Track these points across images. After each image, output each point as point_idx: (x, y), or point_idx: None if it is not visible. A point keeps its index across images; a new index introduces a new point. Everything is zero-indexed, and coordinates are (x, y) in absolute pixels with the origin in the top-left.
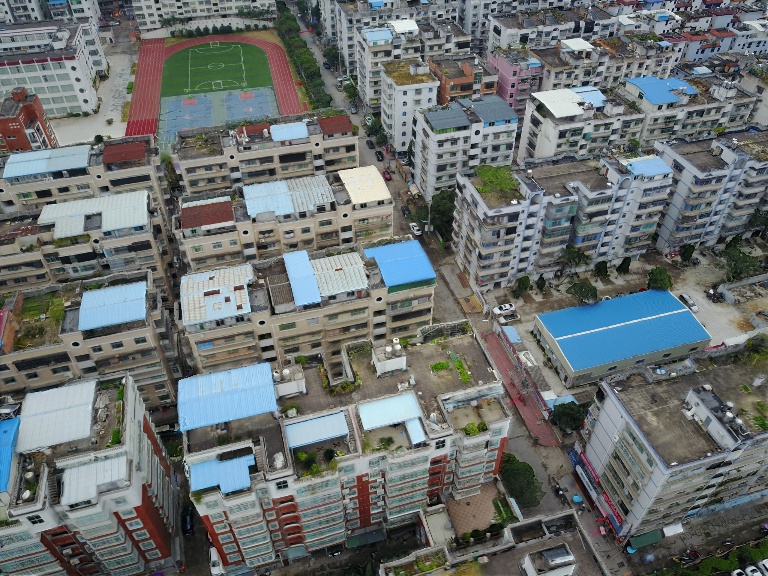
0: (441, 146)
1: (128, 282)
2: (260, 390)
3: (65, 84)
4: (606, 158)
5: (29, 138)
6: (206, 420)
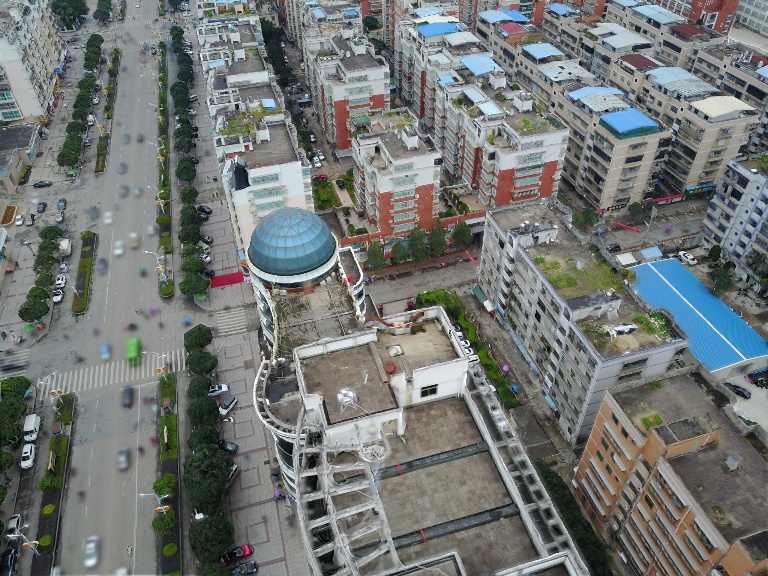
0: None
1: (570, 58)
2: None
3: None
4: None
5: (701, 18)
6: (465, 62)
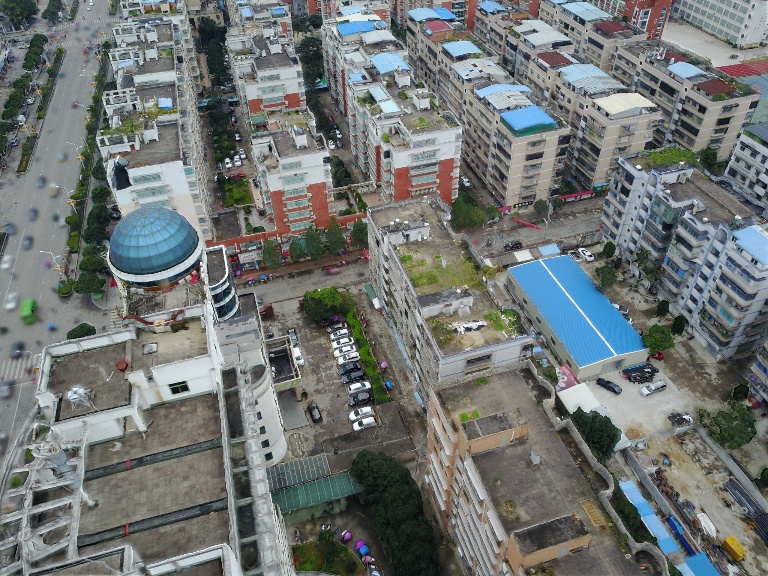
0: (743, 150)
1: None
2: (391, 67)
3: (742, 16)
4: (758, 218)
5: (635, 14)
6: (374, 60)
